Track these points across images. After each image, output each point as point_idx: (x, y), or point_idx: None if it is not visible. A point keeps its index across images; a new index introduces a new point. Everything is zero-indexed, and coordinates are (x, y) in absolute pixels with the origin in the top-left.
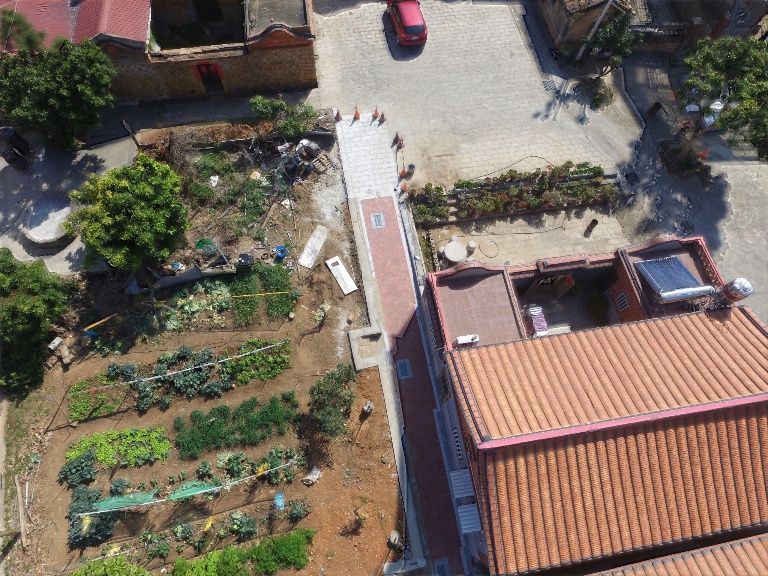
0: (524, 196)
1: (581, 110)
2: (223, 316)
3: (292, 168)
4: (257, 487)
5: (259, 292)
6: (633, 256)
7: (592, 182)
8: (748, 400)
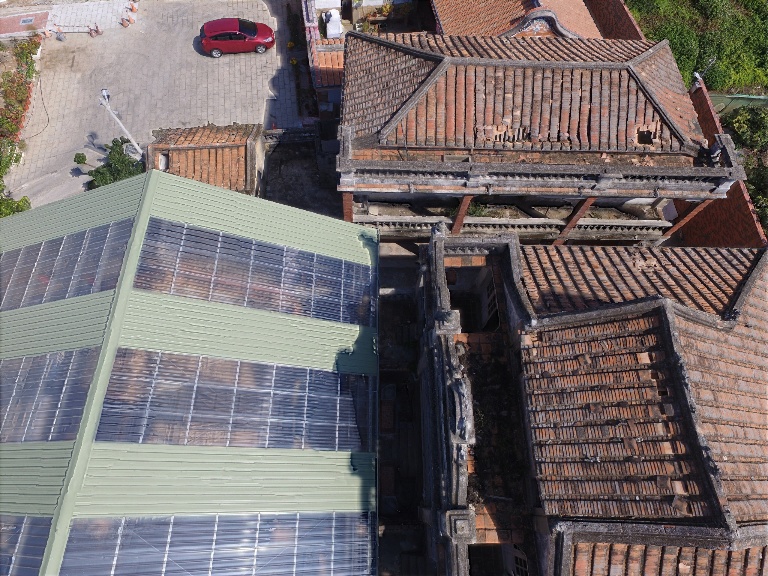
0: (6, 110)
1: None
2: None
3: None
4: None
5: None
6: None
7: None
8: None
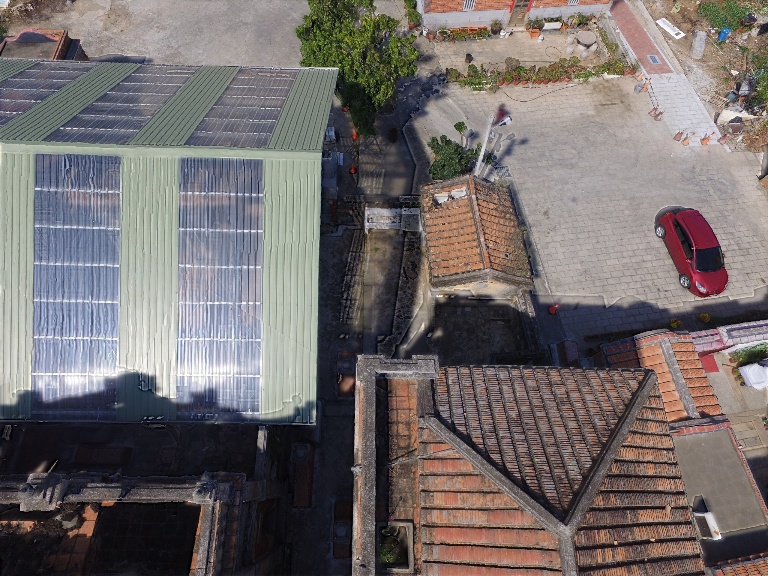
0: None
1: (470, 144)
2: (744, 5)
3: None
4: None
5: None
6: None
7: (469, 79)
8: None
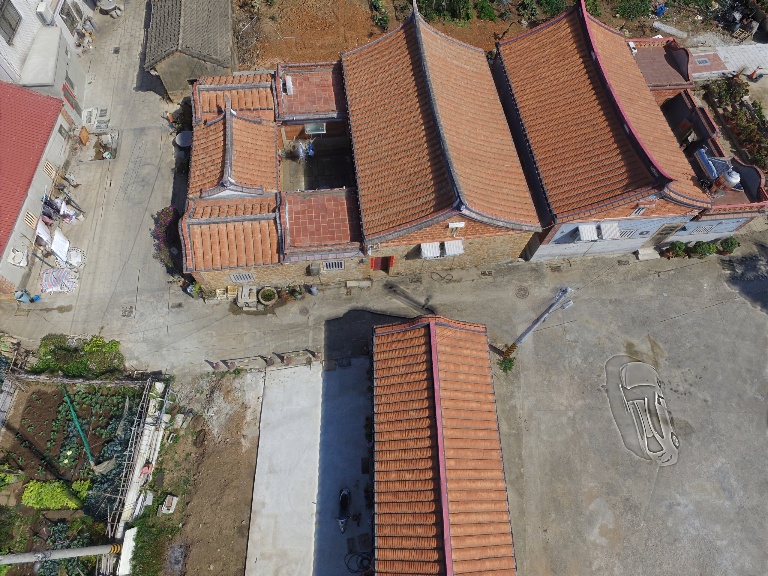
0: None
1: None
2: None
3: (729, 21)
4: (515, 4)
5: (629, 4)
6: (732, 163)
7: None
8: (636, 133)
